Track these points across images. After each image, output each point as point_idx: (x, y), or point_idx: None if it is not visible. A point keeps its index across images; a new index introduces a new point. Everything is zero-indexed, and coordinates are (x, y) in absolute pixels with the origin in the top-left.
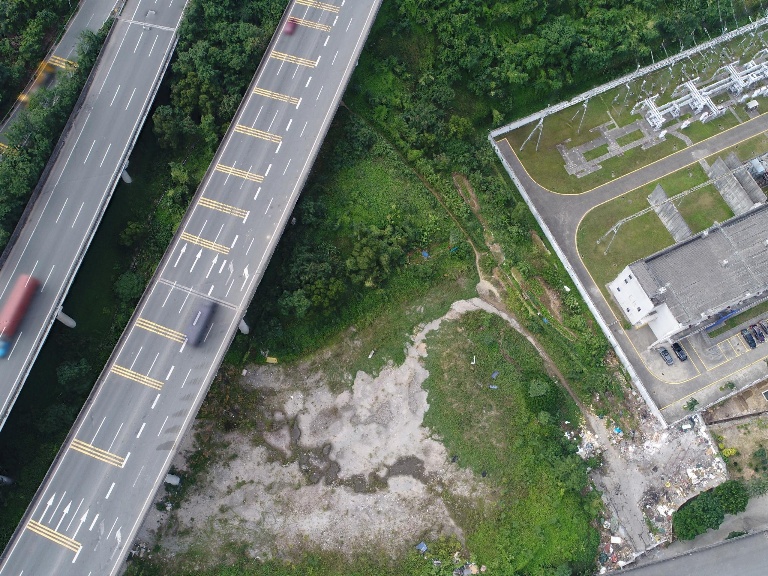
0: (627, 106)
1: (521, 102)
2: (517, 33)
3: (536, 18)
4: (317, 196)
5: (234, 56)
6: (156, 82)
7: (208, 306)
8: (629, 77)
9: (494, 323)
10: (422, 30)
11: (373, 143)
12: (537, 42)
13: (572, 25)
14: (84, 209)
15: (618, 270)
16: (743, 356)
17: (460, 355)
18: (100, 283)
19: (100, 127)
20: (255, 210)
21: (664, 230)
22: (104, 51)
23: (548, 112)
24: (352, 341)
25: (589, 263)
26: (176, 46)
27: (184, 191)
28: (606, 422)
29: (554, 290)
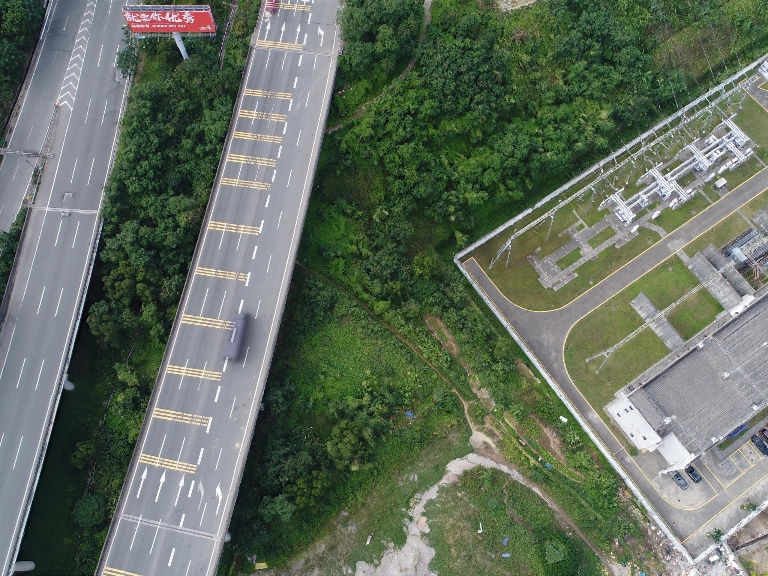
0: (593, 202)
1: (482, 215)
2: (468, 146)
3: (486, 130)
4: (283, 377)
5: (168, 234)
6: (85, 279)
7: (182, 540)
8: (593, 182)
9: (495, 479)
10: (368, 163)
11: (335, 303)
12: (491, 158)
13: (524, 129)
14: (24, 444)
15: (613, 389)
16: (758, 466)
17: (465, 524)
18: (55, 511)
19: (29, 341)
20: (218, 415)
21: (653, 336)
22: (21, 249)
23: (515, 234)
24: (345, 528)
25: (582, 386)
26: (101, 231)
27: (135, 395)
28: (630, 569)
29: (551, 427)
